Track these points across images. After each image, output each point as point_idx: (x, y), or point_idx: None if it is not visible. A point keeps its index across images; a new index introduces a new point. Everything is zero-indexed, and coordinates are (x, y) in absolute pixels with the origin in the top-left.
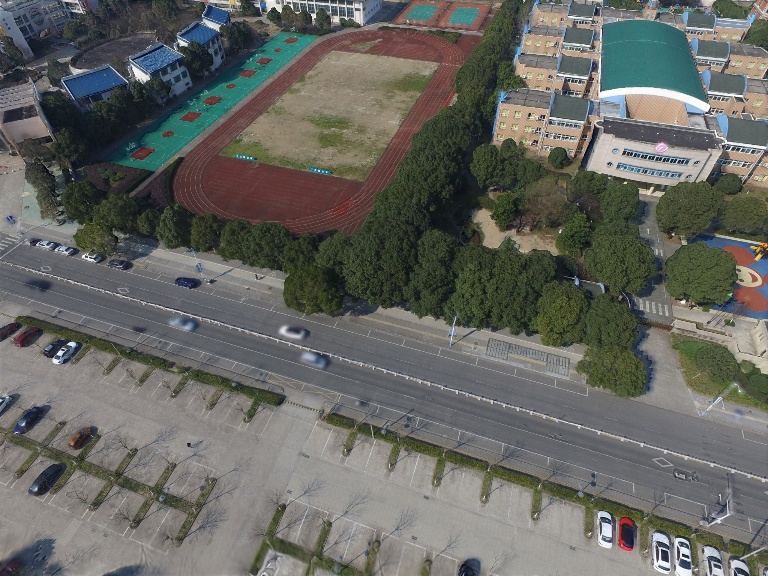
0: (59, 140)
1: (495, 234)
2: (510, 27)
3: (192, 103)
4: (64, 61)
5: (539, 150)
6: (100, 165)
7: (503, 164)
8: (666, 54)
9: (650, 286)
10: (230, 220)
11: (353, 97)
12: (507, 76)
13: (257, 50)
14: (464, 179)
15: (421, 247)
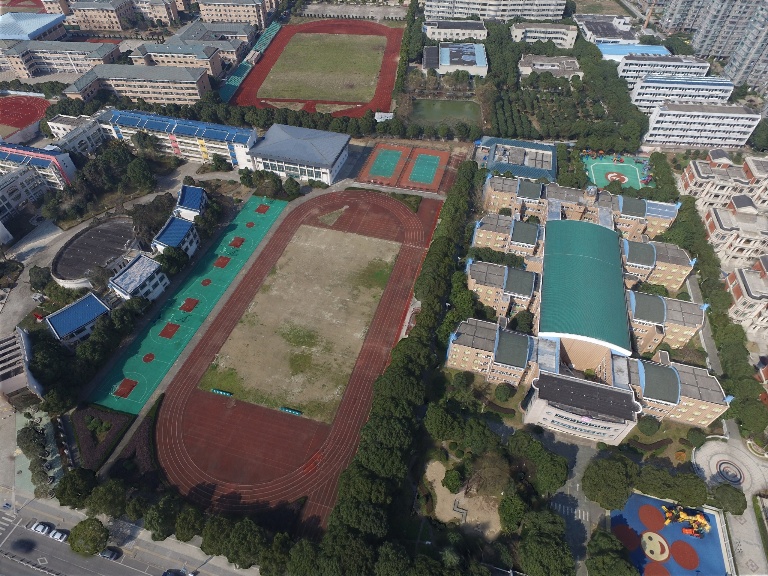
0: (48, 400)
1: (446, 496)
2: (465, 206)
3: (170, 320)
4: (43, 245)
5: (487, 378)
6: (86, 411)
7: (452, 425)
8: (598, 278)
9: (576, 564)
10: (210, 485)
11: (321, 298)
12: (460, 289)
13: (230, 225)
14: (419, 434)
15: (377, 572)
